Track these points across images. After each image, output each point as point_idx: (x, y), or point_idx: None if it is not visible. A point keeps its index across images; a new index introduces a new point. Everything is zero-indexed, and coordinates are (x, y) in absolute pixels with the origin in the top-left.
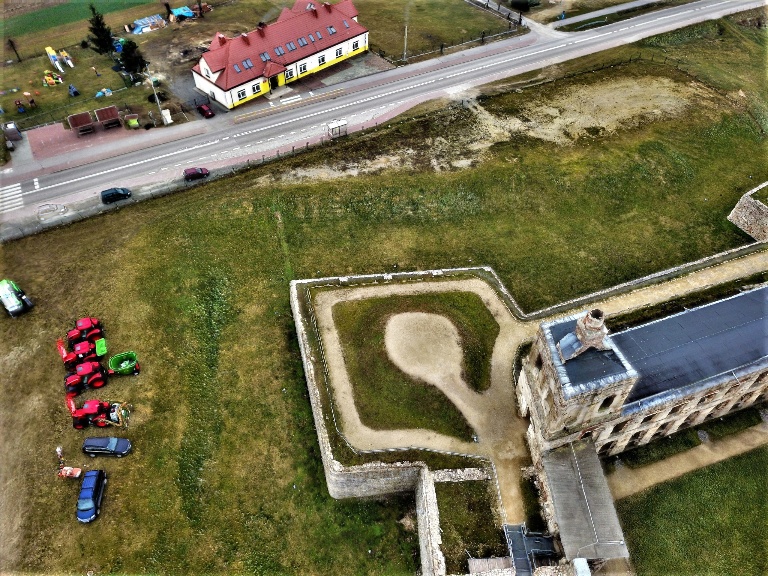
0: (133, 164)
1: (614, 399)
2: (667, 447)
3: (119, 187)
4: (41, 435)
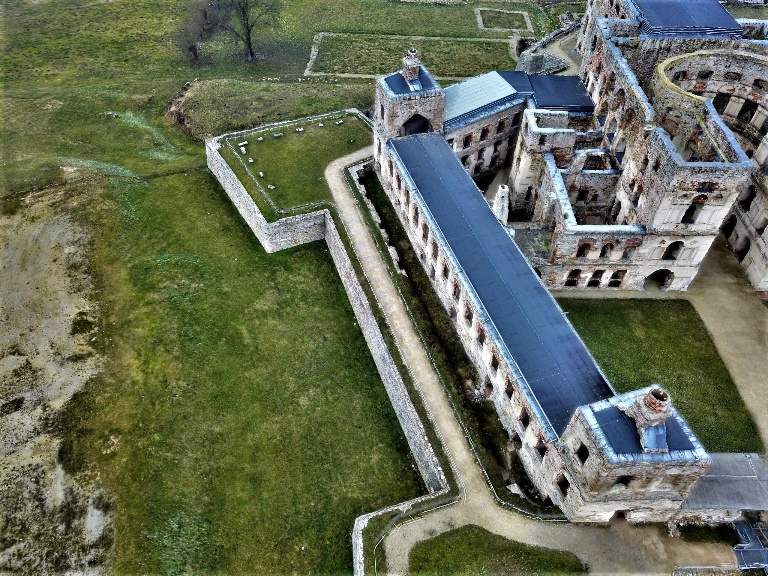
0: None
1: None
2: None
3: None
4: None
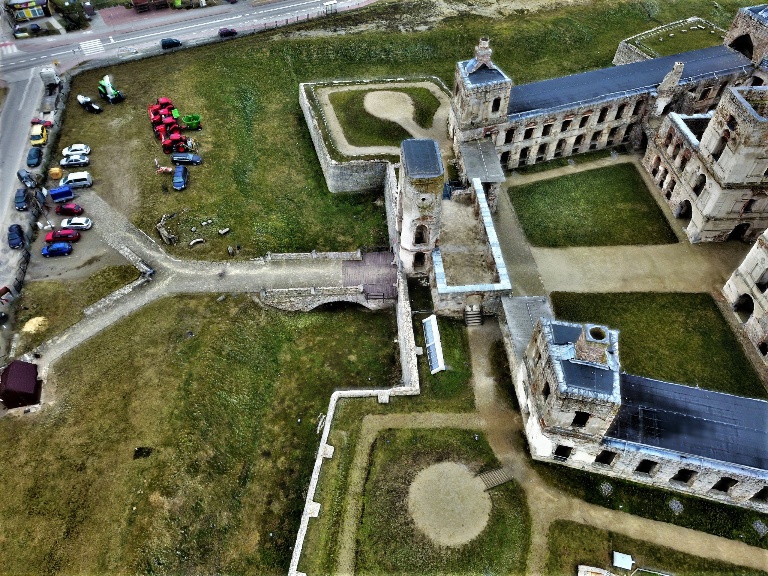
0: (180, 29)
1: (500, 103)
2: (546, 166)
3: None
4: (142, 156)
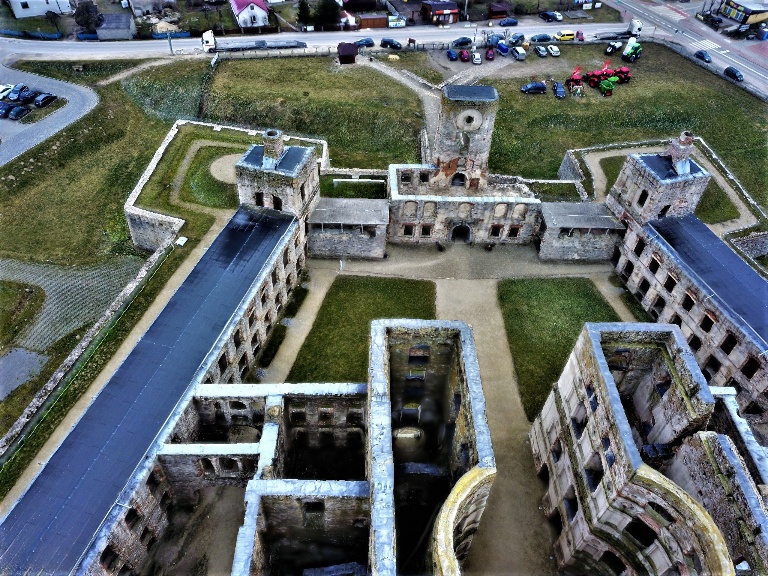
0: None
1: None
2: None
3: (744, 77)
4: (559, 75)
